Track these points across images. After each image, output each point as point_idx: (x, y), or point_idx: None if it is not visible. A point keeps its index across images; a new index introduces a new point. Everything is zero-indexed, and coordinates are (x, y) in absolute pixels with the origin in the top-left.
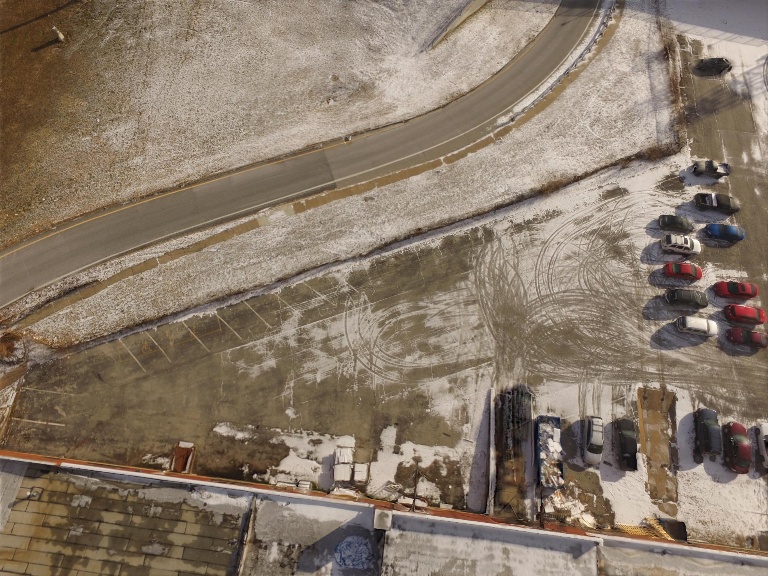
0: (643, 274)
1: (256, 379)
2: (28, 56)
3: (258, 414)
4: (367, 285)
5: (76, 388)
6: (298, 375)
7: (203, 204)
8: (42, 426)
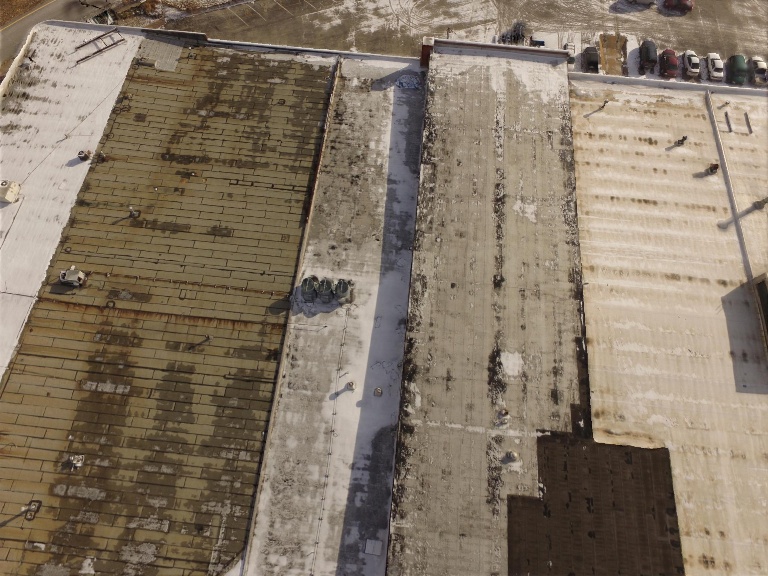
0: None
1: (328, 31)
2: None
3: None
4: None
5: None
6: (358, 28)
7: None
8: None
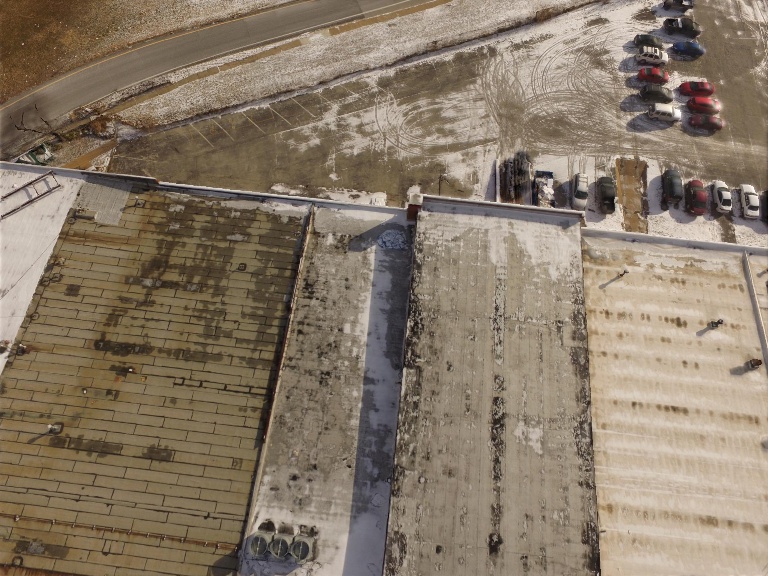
0: (621, 79)
1: (304, 153)
2: None
3: (307, 177)
4: (393, 87)
5: (158, 157)
6: (338, 150)
7: (253, 30)
8: None
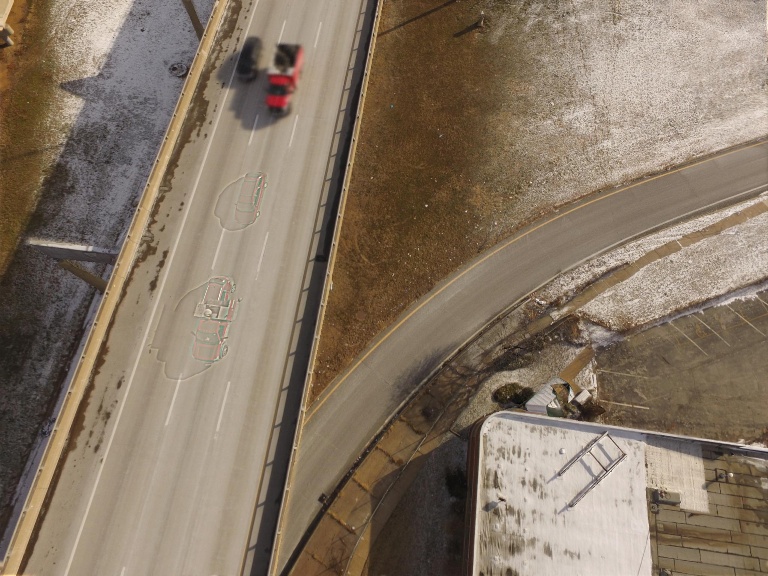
0: None
1: None
2: (452, 41)
3: None
4: None
5: (647, 371)
6: None
7: (698, 187)
8: (629, 409)
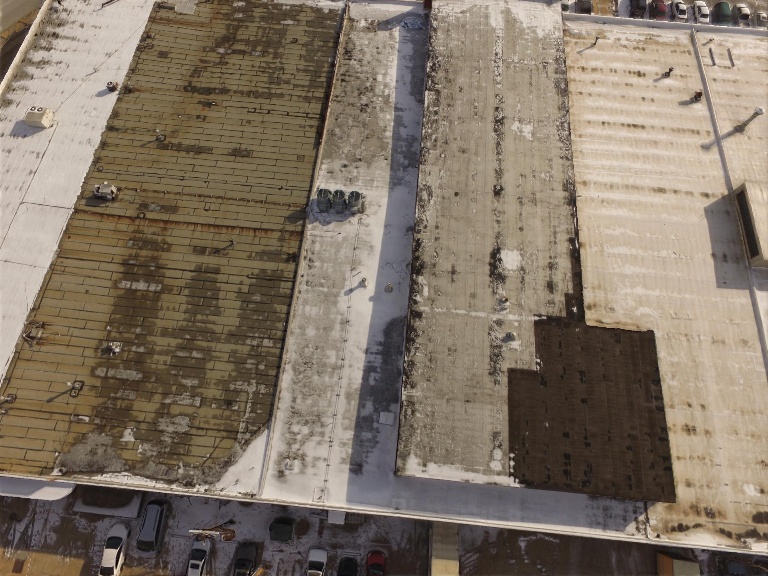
0: None
1: None
2: None
3: None
4: None
5: None
6: None
7: None
8: None
